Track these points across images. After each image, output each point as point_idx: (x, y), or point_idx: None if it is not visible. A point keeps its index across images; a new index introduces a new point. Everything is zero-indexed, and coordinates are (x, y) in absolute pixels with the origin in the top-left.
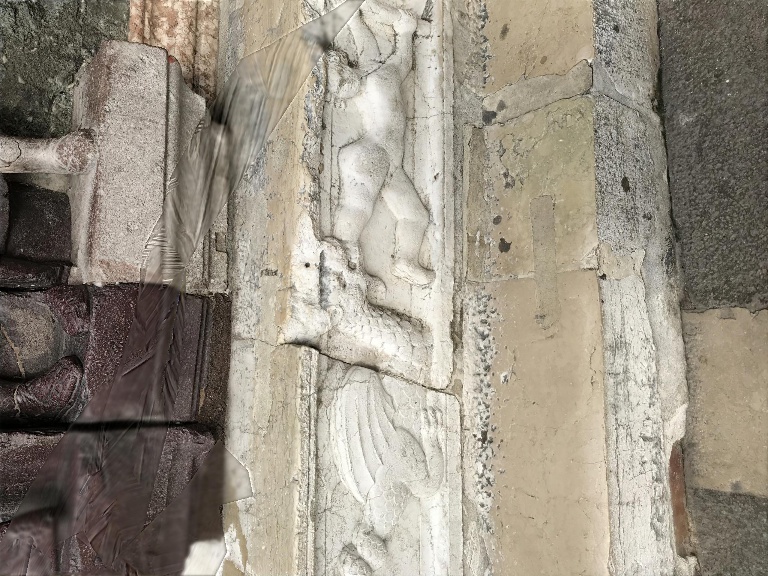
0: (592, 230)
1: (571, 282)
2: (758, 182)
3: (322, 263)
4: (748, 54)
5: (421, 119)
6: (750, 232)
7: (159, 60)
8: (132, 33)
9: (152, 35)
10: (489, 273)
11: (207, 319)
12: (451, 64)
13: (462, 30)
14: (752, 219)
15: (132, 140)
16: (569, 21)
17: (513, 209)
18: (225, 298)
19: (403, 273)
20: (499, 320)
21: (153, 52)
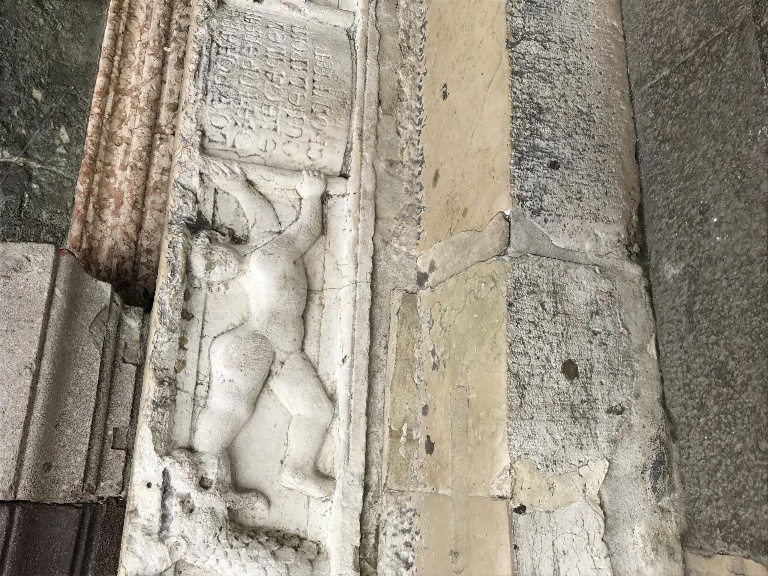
0: (501, 442)
1: (479, 513)
2: (762, 368)
3: (167, 482)
4: (736, 183)
5: (332, 291)
6: (758, 444)
7: (46, 256)
8: (73, 219)
9: (98, 217)
10: (416, 479)
11: (94, 528)
12: (370, 223)
13: (391, 181)
14: (759, 424)
15: (2, 343)
16: (486, 165)
17: (437, 399)
18: (120, 502)
19: (290, 485)
20: (421, 546)
21: (40, 249)
